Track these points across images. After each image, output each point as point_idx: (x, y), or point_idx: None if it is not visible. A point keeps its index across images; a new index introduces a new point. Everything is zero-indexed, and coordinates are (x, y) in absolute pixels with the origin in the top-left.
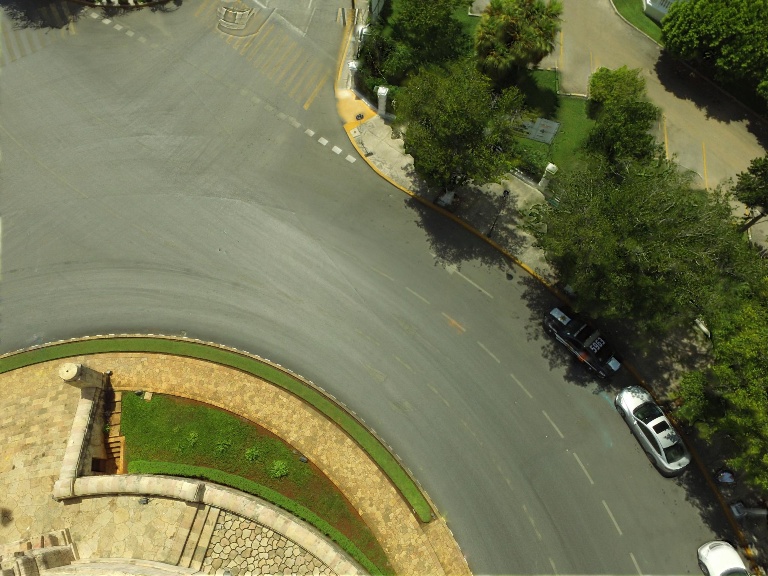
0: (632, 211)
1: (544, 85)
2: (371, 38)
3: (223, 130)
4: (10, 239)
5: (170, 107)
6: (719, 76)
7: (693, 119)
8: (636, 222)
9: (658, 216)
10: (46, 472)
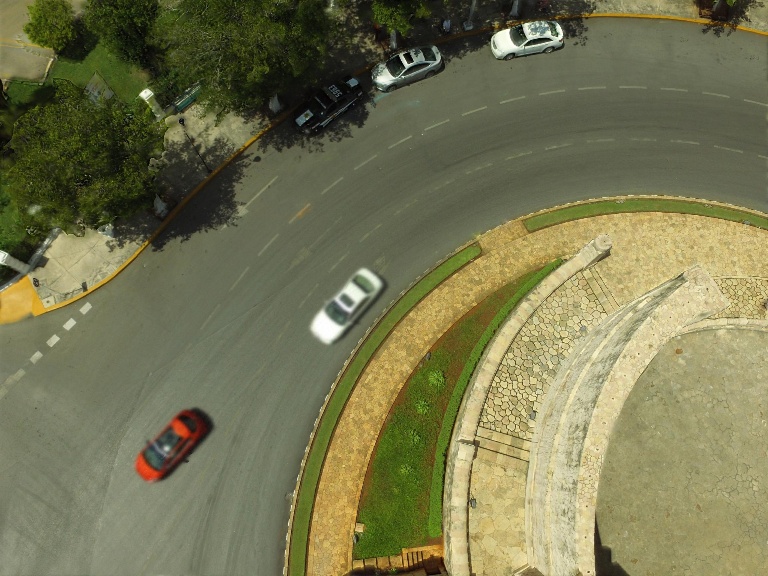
0: None
1: (27, 96)
2: None
3: (6, 472)
4: None
5: None
6: None
7: None
8: None
9: None
10: None
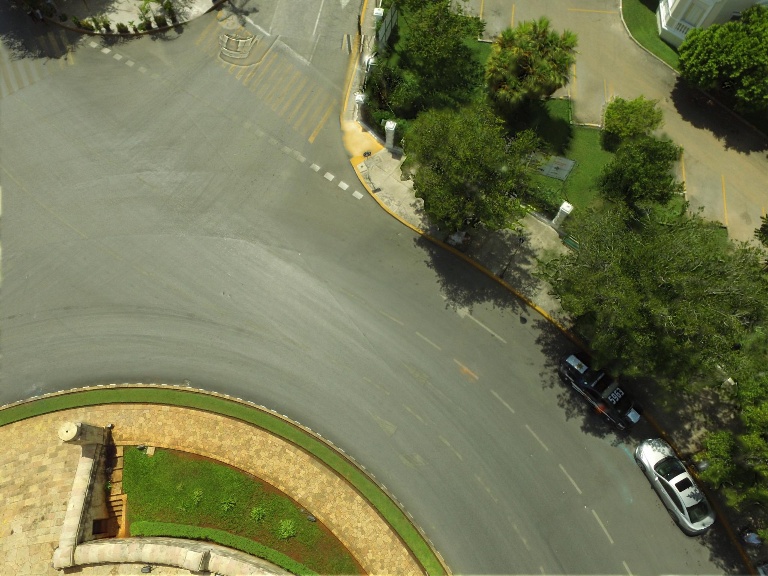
0: (656, 269)
1: (556, 115)
2: (378, 69)
3: (226, 165)
4: (8, 283)
5: (171, 141)
6: (739, 107)
7: (711, 150)
8: (661, 281)
9: (684, 276)
10: (45, 538)
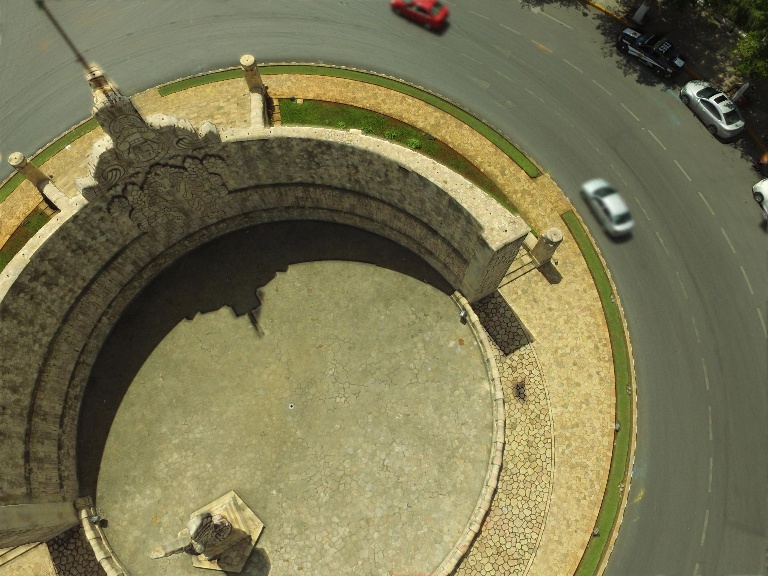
0: None
1: None
2: None
3: None
4: (166, 1)
5: None
6: None
7: None
8: None
9: None
10: None
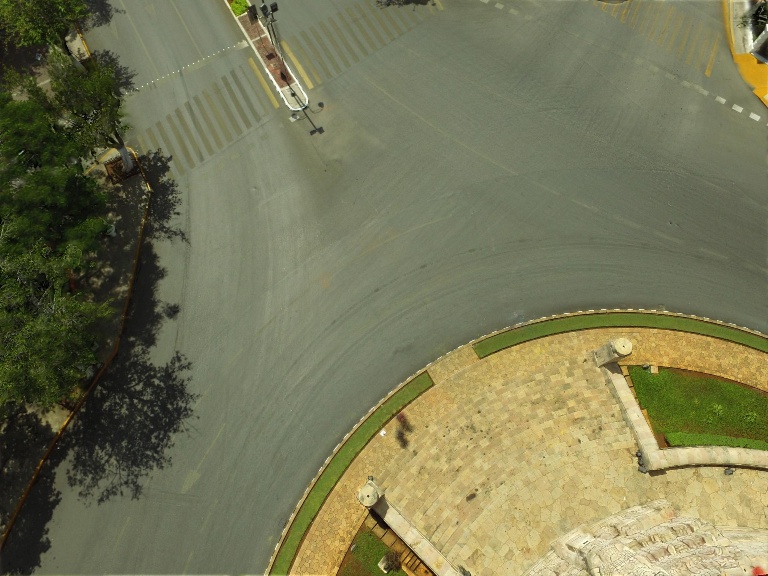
0: None
1: None
2: None
3: (630, 101)
4: (457, 219)
5: (568, 80)
6: None
7: None
8: None
9: None
10: (620, 445)
